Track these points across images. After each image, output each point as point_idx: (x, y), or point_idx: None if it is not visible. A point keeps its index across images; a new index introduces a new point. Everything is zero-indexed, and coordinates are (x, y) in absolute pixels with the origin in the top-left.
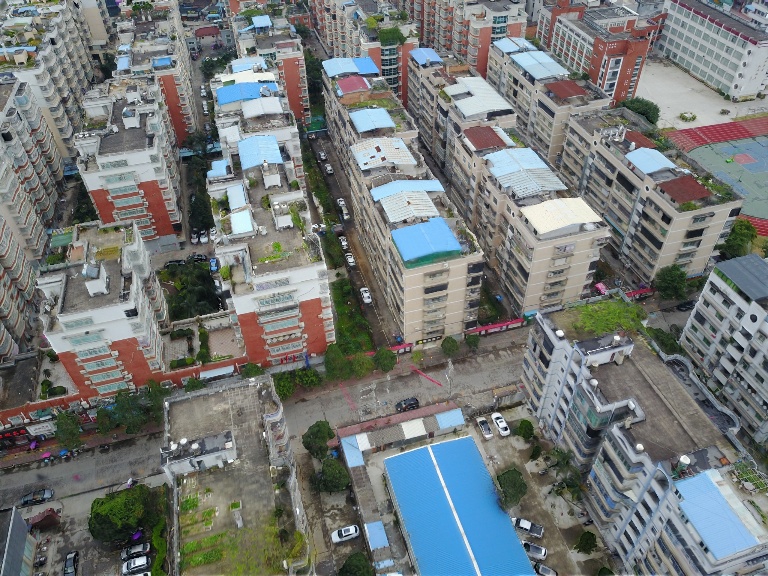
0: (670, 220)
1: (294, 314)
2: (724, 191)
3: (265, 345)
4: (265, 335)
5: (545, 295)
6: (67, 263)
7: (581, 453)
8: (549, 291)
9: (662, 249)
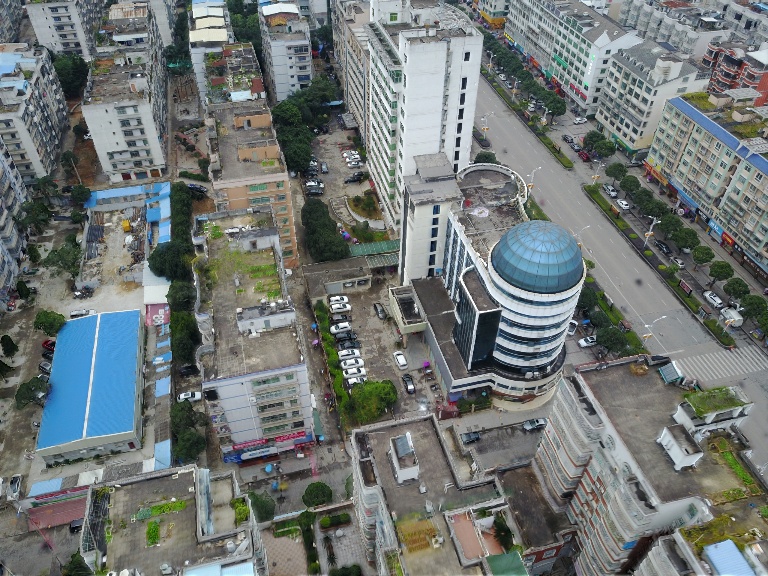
0: None
1: None
2: None
3: None
4: None
5: None
6: (468, 507)
7: None
8: None
9: None
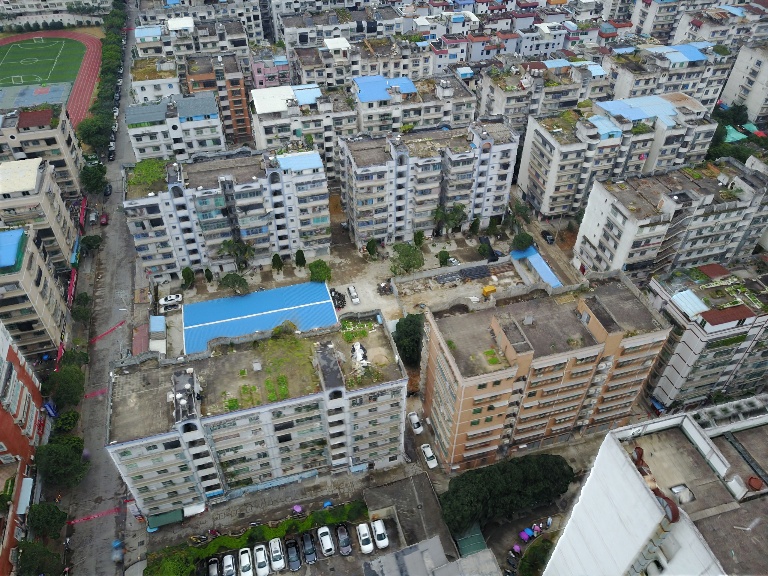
0: (55, 139)
1: (15, 373)
2: (50, 106)
3: (21, 432)
4: (16, 419)
5: (67, 239)
6: None
7: (229, 234)
8: (66, 234)
9: (67, 164)
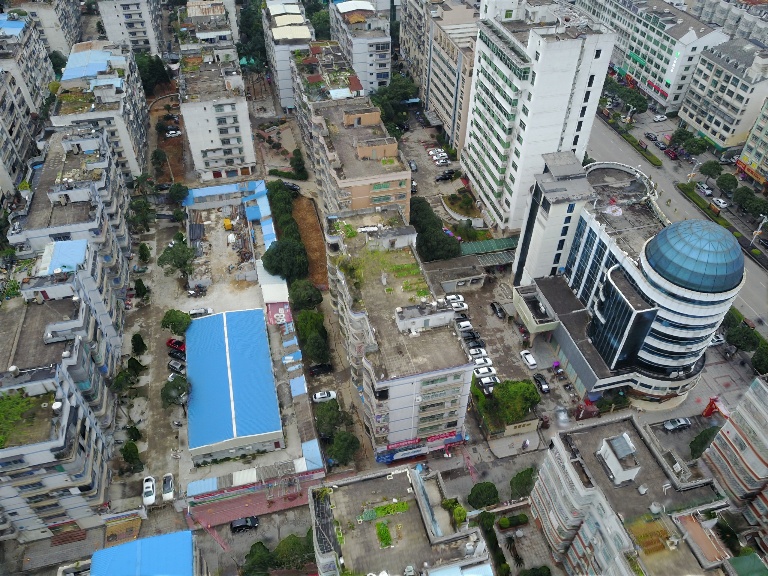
0: None
1: None
2: None
3: None
4: None
5: None
6: (694, 508)
7: None
8: None
9: None
